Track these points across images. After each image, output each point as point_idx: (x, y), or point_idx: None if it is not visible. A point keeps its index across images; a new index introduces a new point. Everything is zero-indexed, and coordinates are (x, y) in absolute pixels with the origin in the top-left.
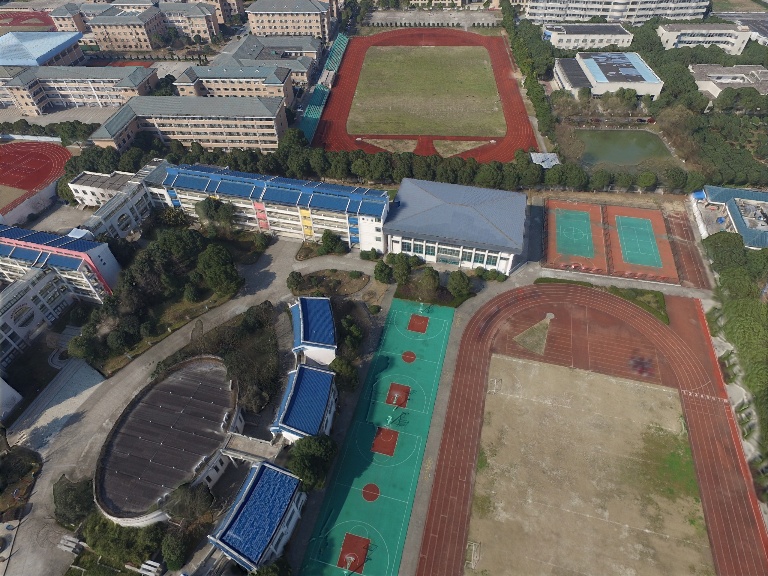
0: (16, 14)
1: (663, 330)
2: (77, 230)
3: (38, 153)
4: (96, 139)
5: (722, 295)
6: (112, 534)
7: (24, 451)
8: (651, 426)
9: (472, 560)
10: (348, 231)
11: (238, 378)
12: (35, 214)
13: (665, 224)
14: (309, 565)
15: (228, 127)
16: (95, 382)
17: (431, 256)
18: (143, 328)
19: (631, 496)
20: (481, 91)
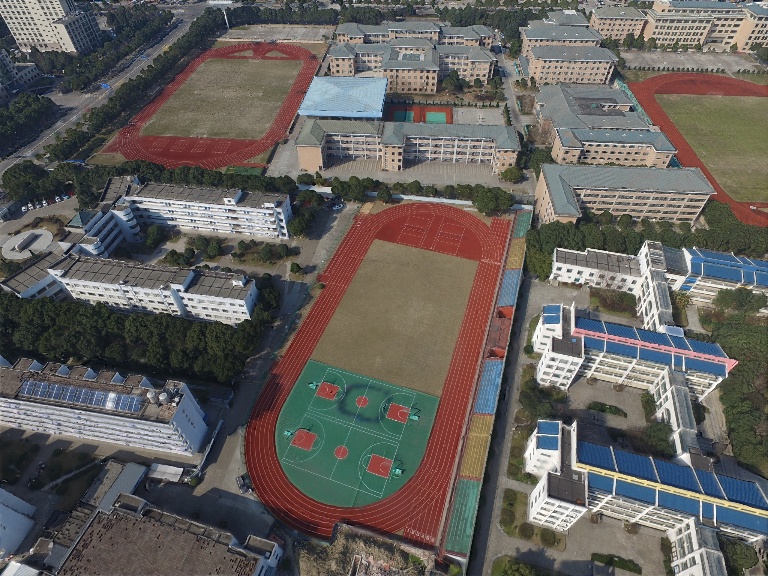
0: (250, 45)
1: None
2: (669, 327)
3: (444, 216)
4: (563, 215)
5: None
6: None
7: None
8: None
9: None
10: None
11: None
12: (519, 291)
13: None
14: None
15: (656, 199)
16: None
17: None
18: None
19: None
20: None
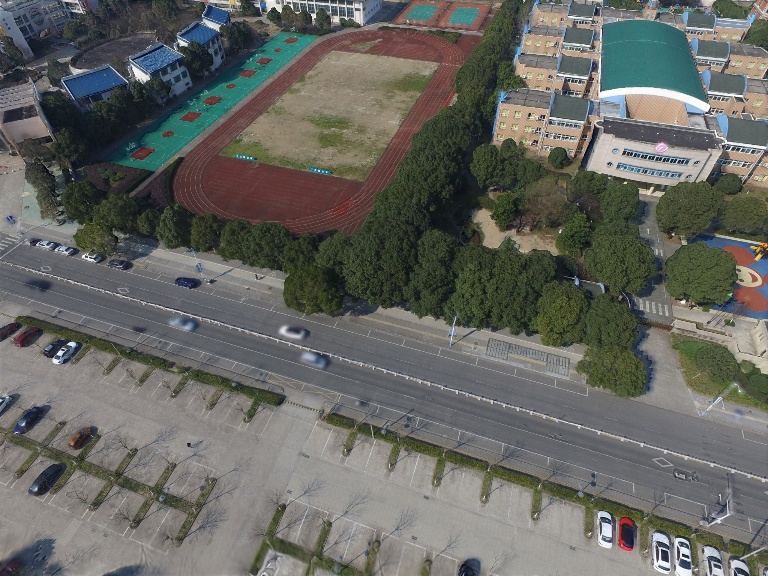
0: None
1: (450, 45)
2: None
3: None
4: None
5: None
6: None
7: None
8: (412, 72)
9: (277, 103)
10: None
11: (163, 37)
12: None
13: (489, 10)
14: (186, 103)
15: None
16: None
17: (313, 14)
18: (112, 31)
19: (382, 90)
20: None
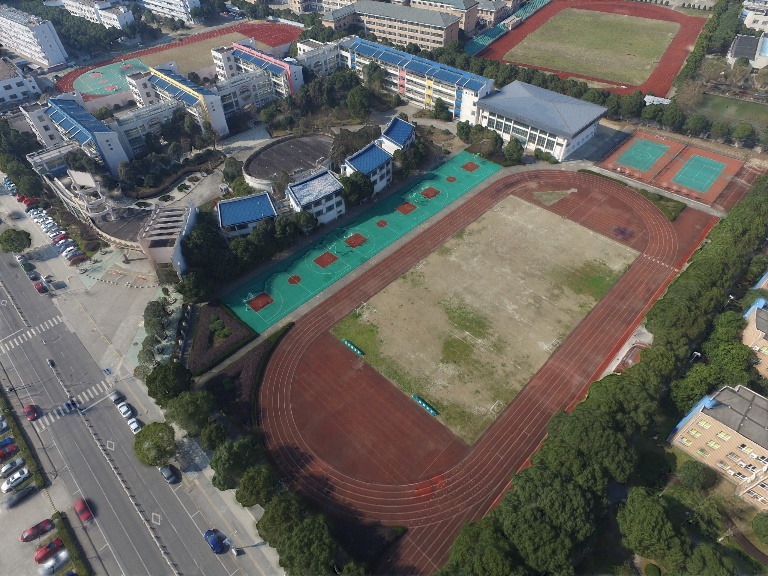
0: None
1: (664, 223)
2: (290, 58)
3: (289, 31)
4: (324, 19)
5: (733, 209)
6: (244, 186)
7: (220, 152)
8: (598, 260)
9: (419, 266)
10: (454, 103)
11: (338, 146)
12: None
13: (739, 170)
14: (329, 236)
15: (411, 31)
16: (266, 138)
17: (507, 134)
18: (302, 119)
19: (548, 281)
20: (645, 53)
